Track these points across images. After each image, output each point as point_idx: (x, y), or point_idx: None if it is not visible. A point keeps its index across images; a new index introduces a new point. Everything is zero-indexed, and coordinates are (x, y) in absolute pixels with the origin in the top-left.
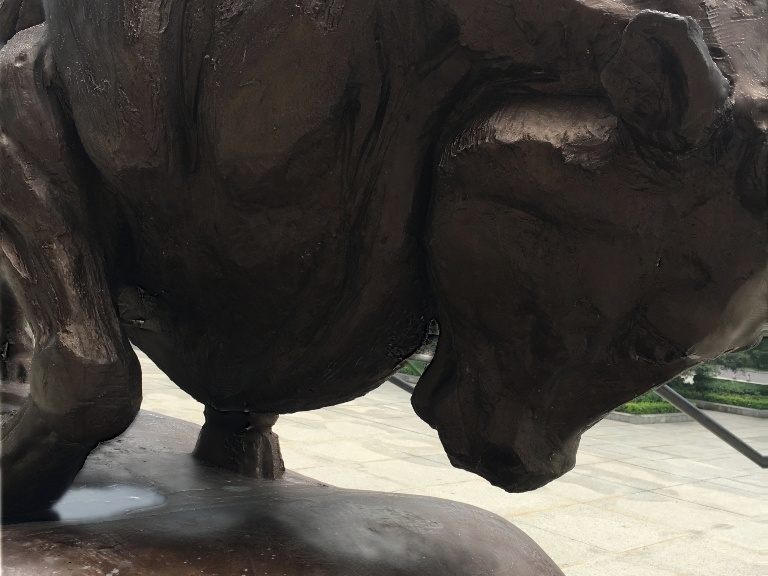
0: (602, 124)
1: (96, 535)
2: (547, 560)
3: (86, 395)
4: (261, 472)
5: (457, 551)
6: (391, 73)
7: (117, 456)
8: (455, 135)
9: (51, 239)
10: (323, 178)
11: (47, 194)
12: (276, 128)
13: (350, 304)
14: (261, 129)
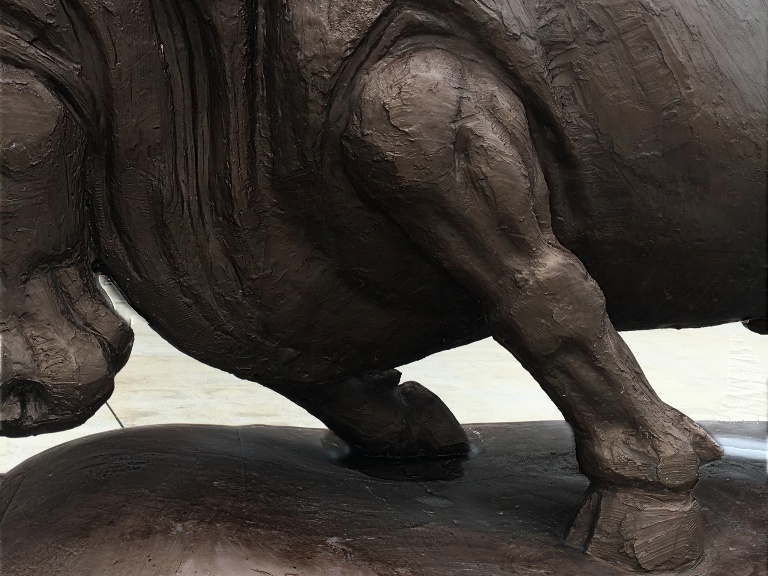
0: None
1: None
2: (69, 570)
3: None
4: (584, 538)
5: (54, 487)
6: None
7: None
8: None
9: None
10: None
11: None
12: None
13: None
14: None
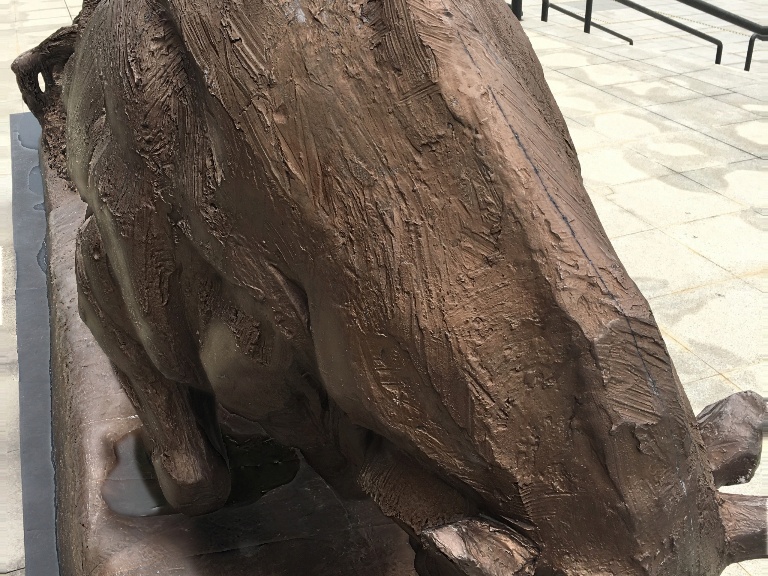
0: (456, 520)
1: None
2: None
3: (184, 501)
4: None
5: None
6: (324, 387)
7: None
8: (368, 461)
9: (146, 386)
10: (300, 424)
11: (136, 356)
12: (251, 403)
13: (350, 477)
14: (241, 402)
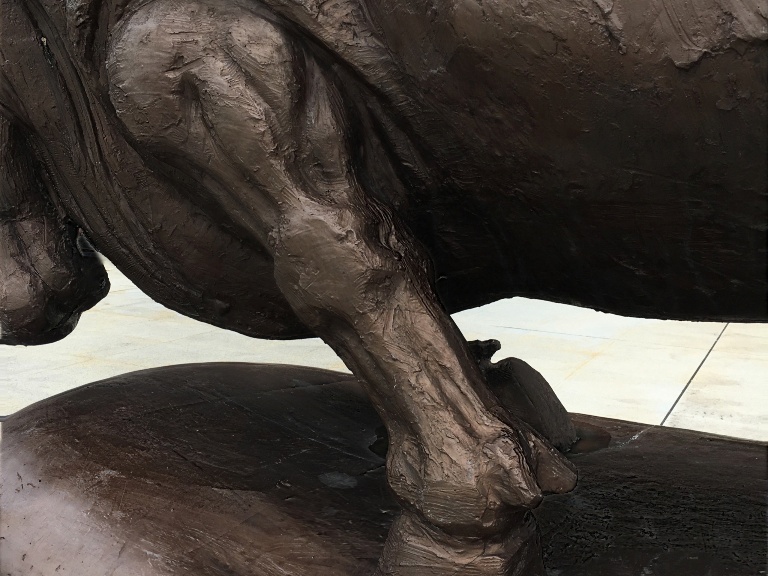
0: None
1: (301, 368)
2: None
3: None
4: None
5: None
6: None
7: (569, 503)
8: None
9: None
10: None
11: None
12: None
13: None
14: None
